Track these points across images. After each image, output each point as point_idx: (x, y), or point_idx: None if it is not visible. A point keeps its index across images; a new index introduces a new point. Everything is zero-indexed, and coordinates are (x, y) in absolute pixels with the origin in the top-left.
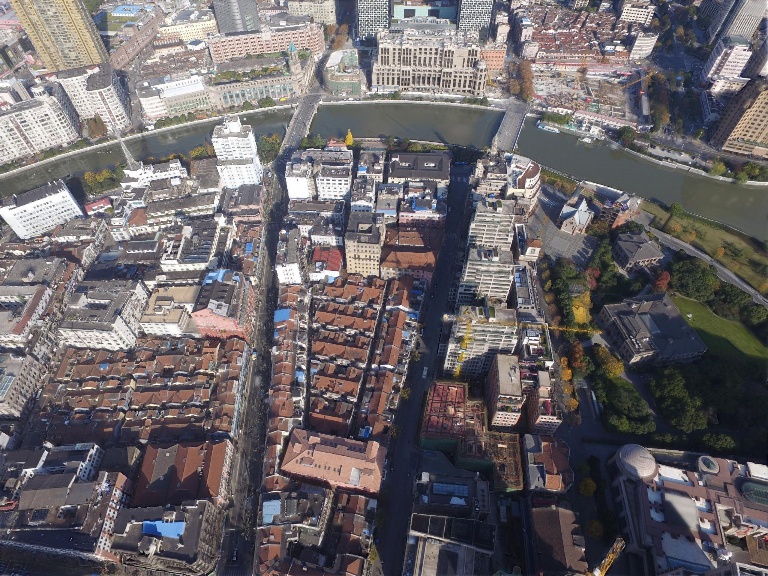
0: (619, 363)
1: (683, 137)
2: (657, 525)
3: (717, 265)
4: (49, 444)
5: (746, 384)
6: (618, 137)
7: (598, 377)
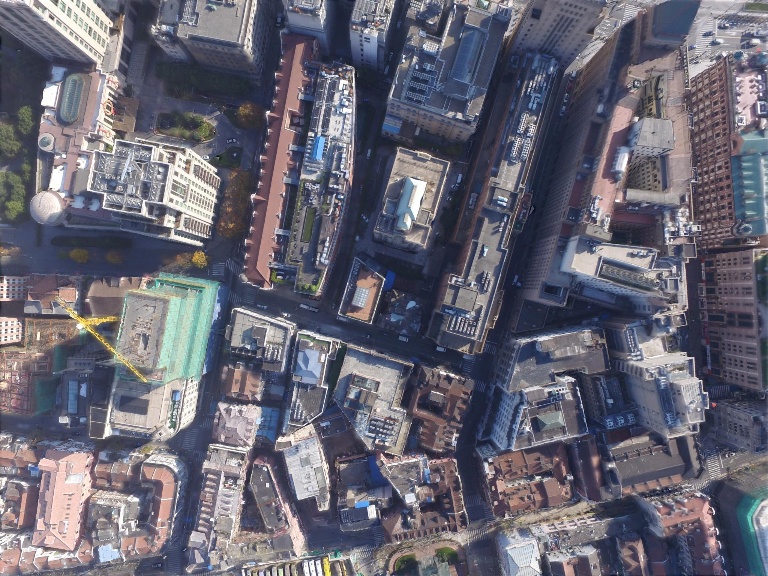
0: None
1: None
2: None
3: None
4: None
5: None
6: None
7: None
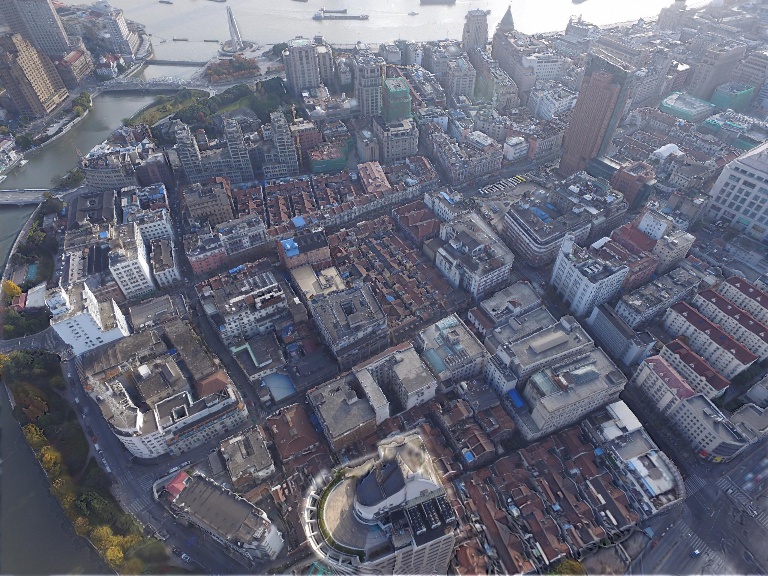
0: None
1: (25, 127)
2: None
3: None
4: None
5: None
6: (25, 147)
7: None
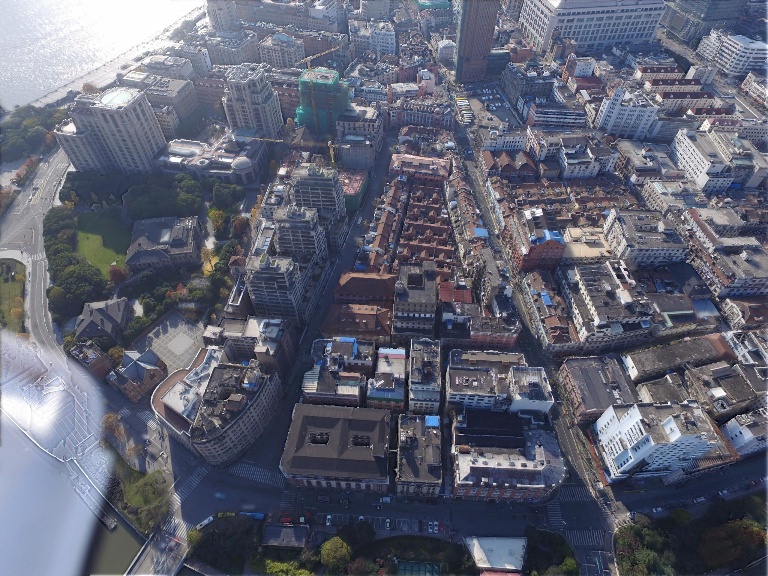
0: (213, 213)
1: None
2: (251, 144)
3: (29, 313)
4: (593, 158)
5: (133, 201)
6: None
7: (233, 211)
